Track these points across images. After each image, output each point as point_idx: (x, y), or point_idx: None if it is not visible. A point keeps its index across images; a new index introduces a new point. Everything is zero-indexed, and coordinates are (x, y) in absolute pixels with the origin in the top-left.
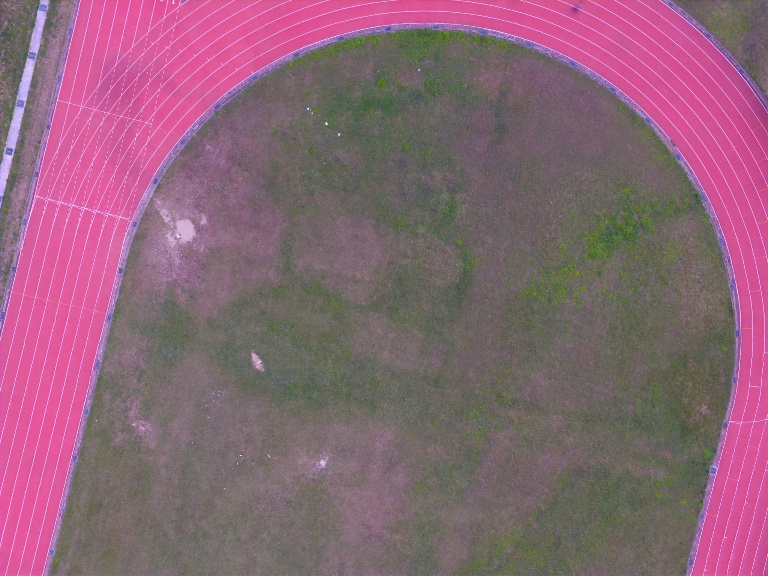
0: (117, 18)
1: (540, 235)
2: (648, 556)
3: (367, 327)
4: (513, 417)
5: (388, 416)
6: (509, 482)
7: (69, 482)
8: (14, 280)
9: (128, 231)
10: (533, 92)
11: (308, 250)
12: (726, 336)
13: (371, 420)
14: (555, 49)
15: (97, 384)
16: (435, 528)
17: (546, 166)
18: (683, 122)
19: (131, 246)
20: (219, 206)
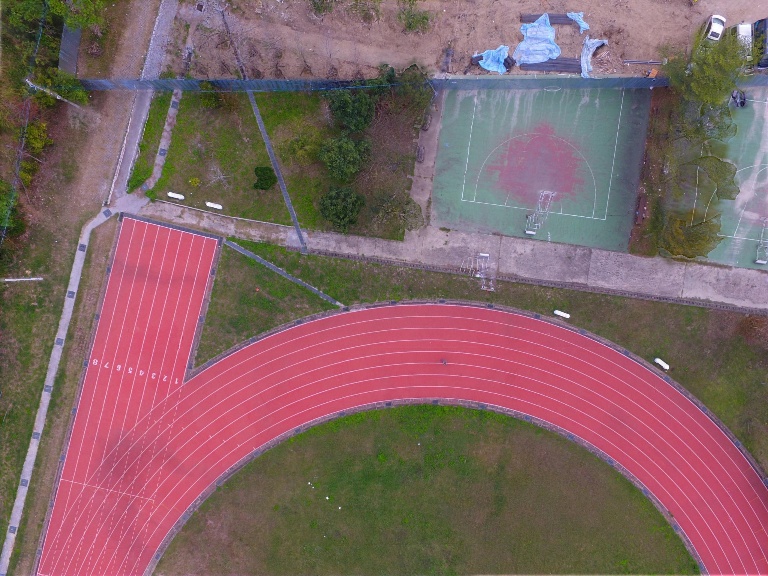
0: (121, 398)
1: None
2: None
3: None
4: None
5: None
6: None
7: None
8: None
9: None
10: (532, 465)
11: None
12: None
13: None
14: (553, 422)
15: None
16: None
17: (545, 538)
18: (680, 493)
19: None
20: None
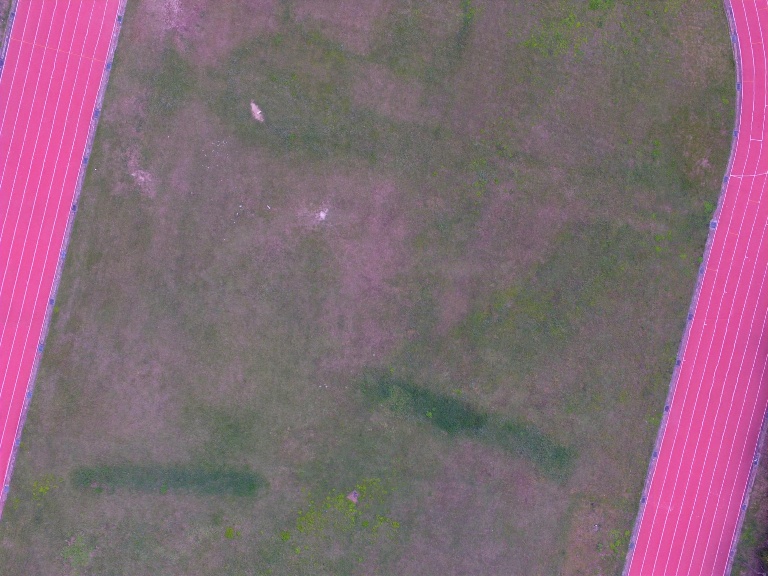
0: None
1: None
2: (648, 310)
3: (367, 78)
4: (513, 170)
5: (388, 168)
6: (509, 235)
7: (69, 232)
8: (12, 26)
9: None
10: None
11: None
12: (727, 88)
13: (371, 172)
14: None
15: (96, 133)
16: (435, 281)
17: None
18: None
19: None
20: None
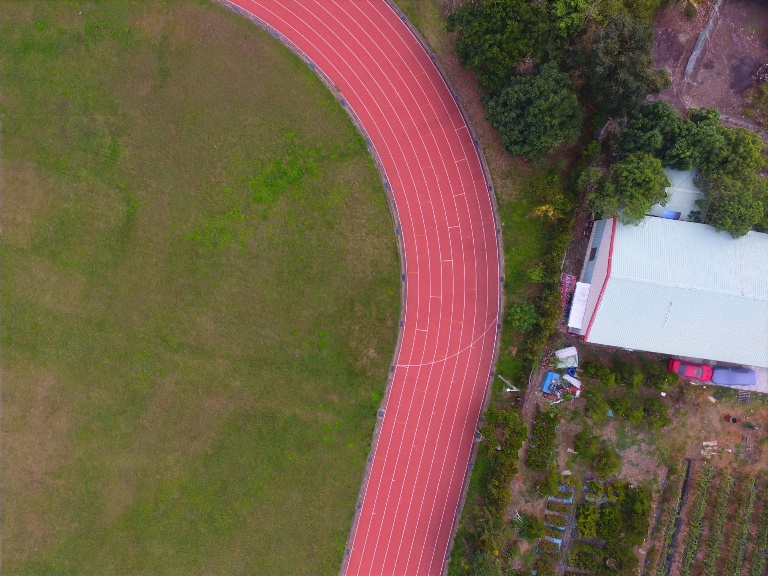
0: None
1: (205, 179)
2: (316, 500)
3: (29, 271)
4: (178, 361)
5: (50, 360)
6: (175, 427)
7: None
8: None
9: None
10: (196, 36)
11: None
12: (391, 280)
13: (33, 364)
14: None
15: None
16: (99, 473)
17: (210, 110)
18: (347, 68)
19: None
20: None
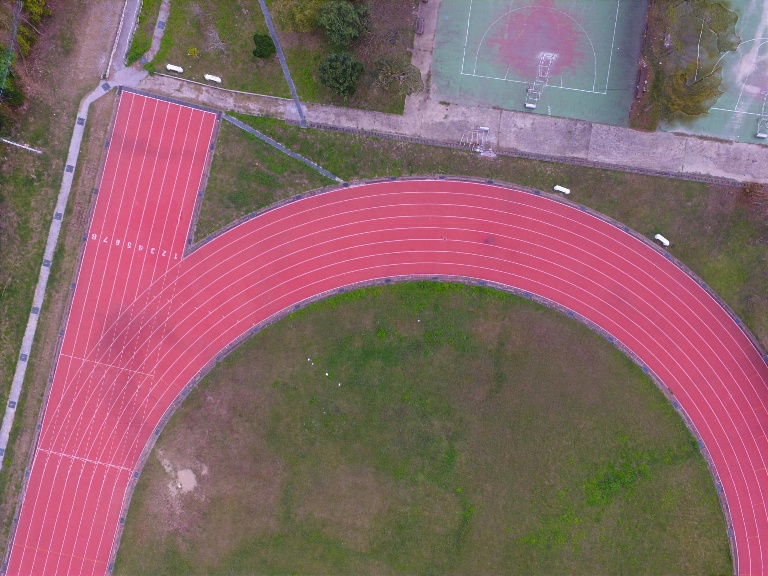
0: (120, 273)
1: (539, 482)
2: None
3: (367, 574)
4: None
5: None
6: None
7: None
8: (16, 532)
9: (130, 481)
10: (531, 342)
11: (308, 499)
12: None
13: None
14: (553, 299)
15: None
16: None
17: (545, 415)
18: (680, 370)
19: (132, 496)
20: (220, 456)
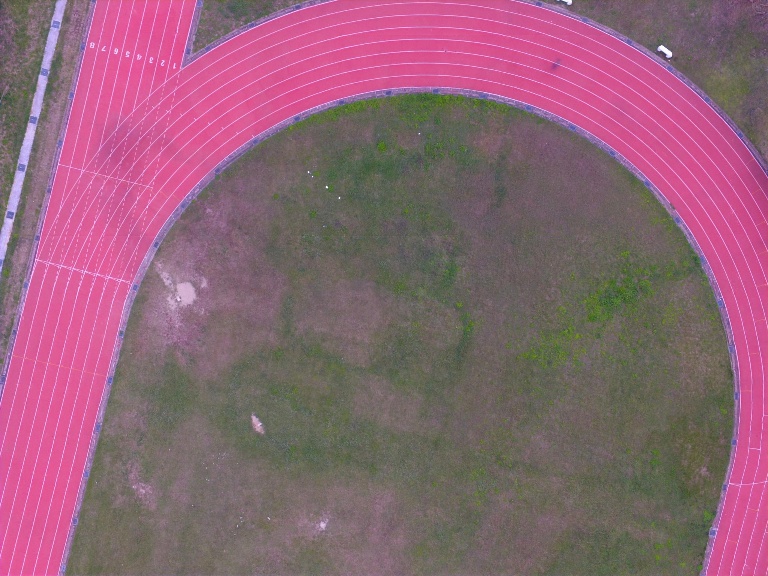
0: (118, 82)
1: (540, 298)
2: None
3: (367, 389)
4: (513, 479)
5: (388, 478)
6: (509, 544)
7: (69, 545)
8: (15, 343)
9: (129, 294)
10: (533, 156)
11: (308, 313)
12: (725, 398)
13: (371, 482)
14: (555, 113)
15: (97, 447)
16: None
17: (546, 229)
18: (682, 185)
19: (132, 309)
20: (219, 269)
